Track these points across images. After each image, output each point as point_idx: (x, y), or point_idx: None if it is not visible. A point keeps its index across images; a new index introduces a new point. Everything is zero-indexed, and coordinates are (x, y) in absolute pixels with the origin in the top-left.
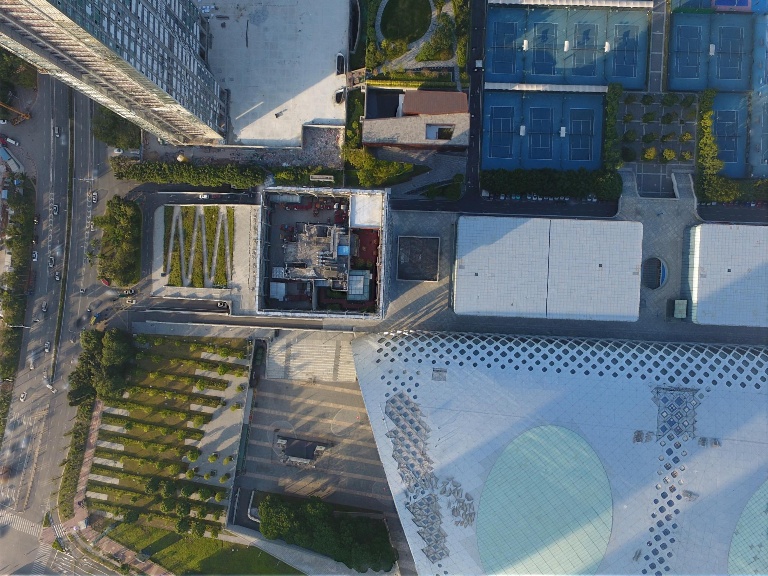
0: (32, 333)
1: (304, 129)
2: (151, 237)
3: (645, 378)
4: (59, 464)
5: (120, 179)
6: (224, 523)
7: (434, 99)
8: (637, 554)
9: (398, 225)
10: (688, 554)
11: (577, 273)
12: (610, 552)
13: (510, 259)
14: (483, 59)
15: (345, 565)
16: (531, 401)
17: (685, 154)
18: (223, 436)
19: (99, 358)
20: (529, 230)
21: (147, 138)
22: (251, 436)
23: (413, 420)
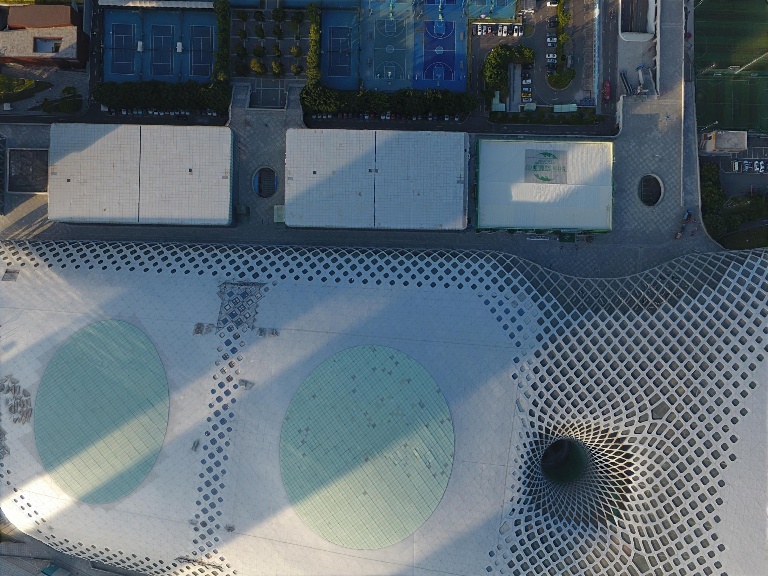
0: None
1: None
2: None
3: (216, 274)
4: None
5: None
6: None
7: (38, 12)
8: (195, 444)
9: (11, 138)
10: (245, 442)
11: (168, 178)
12: (167, 443)
13: (102, 165)
14: None
15: None
16: (96, 298)
17: None
18: None
19: None
20: (120, 136)
21: None
22: None
23: None
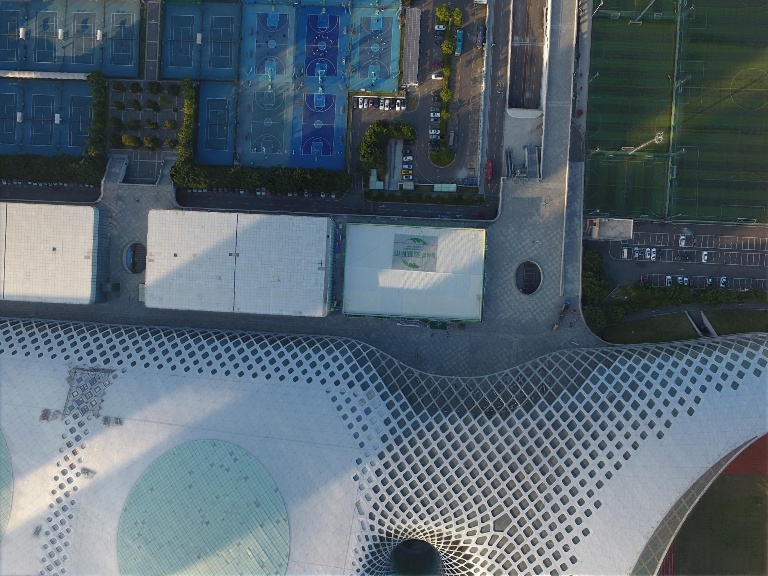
0: None
1: None
2: None
3: (68, 359)
4: None
5: None
6: None
7: None
8: (38, 529)
9: None
10: (85, 530)
11: (32, 256)
12: (11, 527)
13: None
14: None
15: None
16: None
17: None
18: None
19: None
20: None
21: None
22: None
23: None
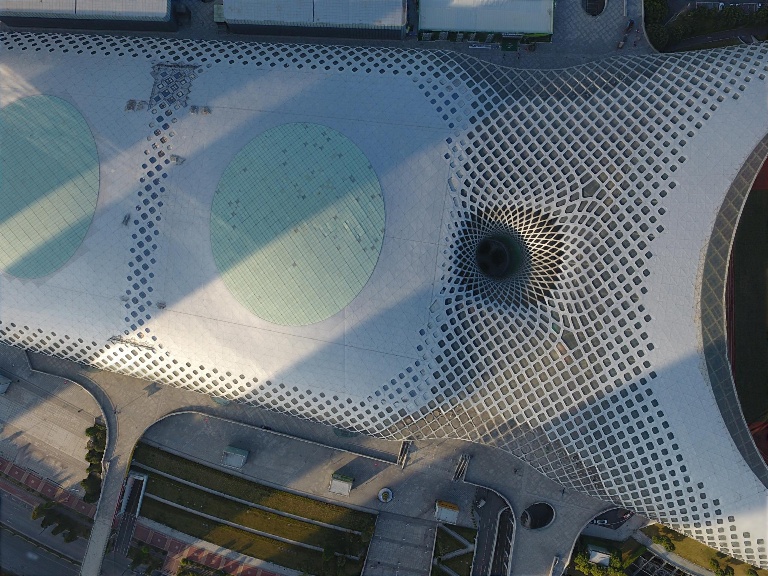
0: None
1: None
2: None
3: (150, 57)
4: None
5: None
6: None
7: None
8: (126, 219)
9: None
10: (176, 217)
11: None
12: (98, 216)
13: None
14: None
15: None
16: (28, 74)
17: None
18: None
19: None
20: None
21: None
22: None
23: None
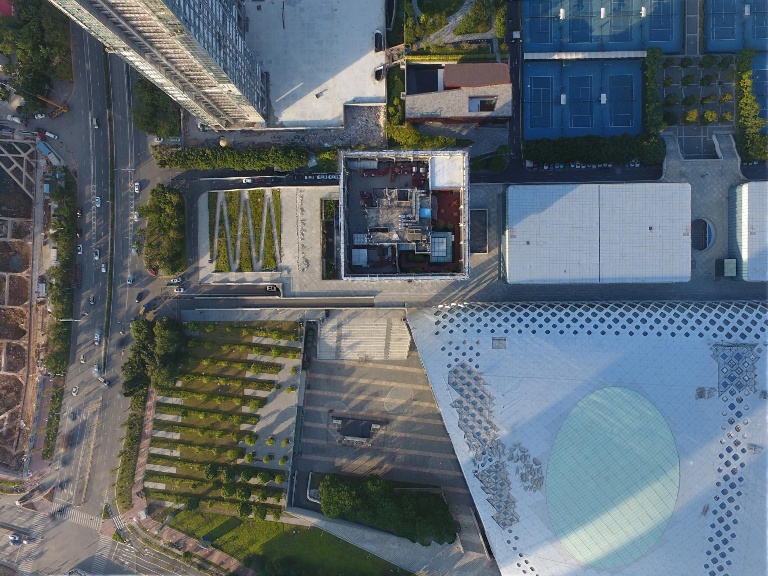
0: (81, 327)
1: (344, 109)
2: (196, 224)
3: (703, 336)
4: (115, 456)
5: (163, 167)
6: (284, 505)
7: (476, 71)
8: (705, 509)
9: None
10: (755, 506)
11: (628, 237)
12: (679, 508)
13: (561, 226)
14: (520, 30)
15: (407, 540)
16: (592, 364)
17: (726, 115)
18: (279, 419)
19: (152, 347)
20: (578, 196)
21: (187, 125)
22: (305, 418)
23: (476, 389)
